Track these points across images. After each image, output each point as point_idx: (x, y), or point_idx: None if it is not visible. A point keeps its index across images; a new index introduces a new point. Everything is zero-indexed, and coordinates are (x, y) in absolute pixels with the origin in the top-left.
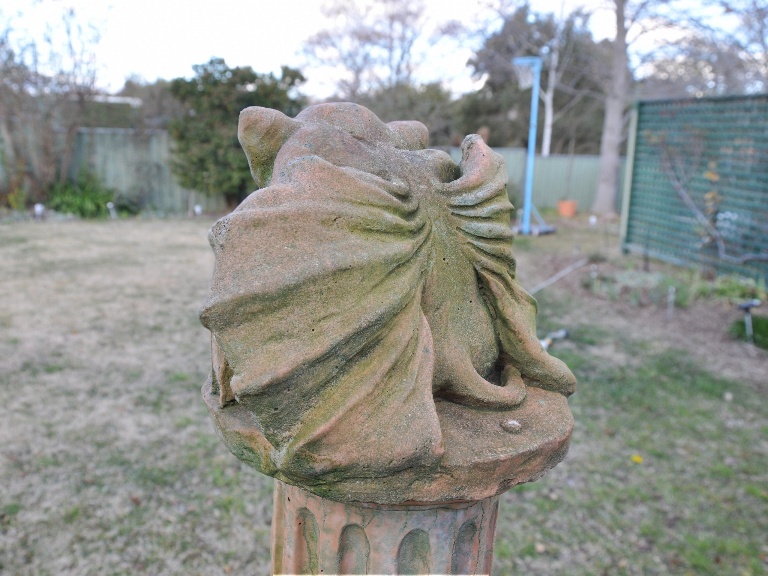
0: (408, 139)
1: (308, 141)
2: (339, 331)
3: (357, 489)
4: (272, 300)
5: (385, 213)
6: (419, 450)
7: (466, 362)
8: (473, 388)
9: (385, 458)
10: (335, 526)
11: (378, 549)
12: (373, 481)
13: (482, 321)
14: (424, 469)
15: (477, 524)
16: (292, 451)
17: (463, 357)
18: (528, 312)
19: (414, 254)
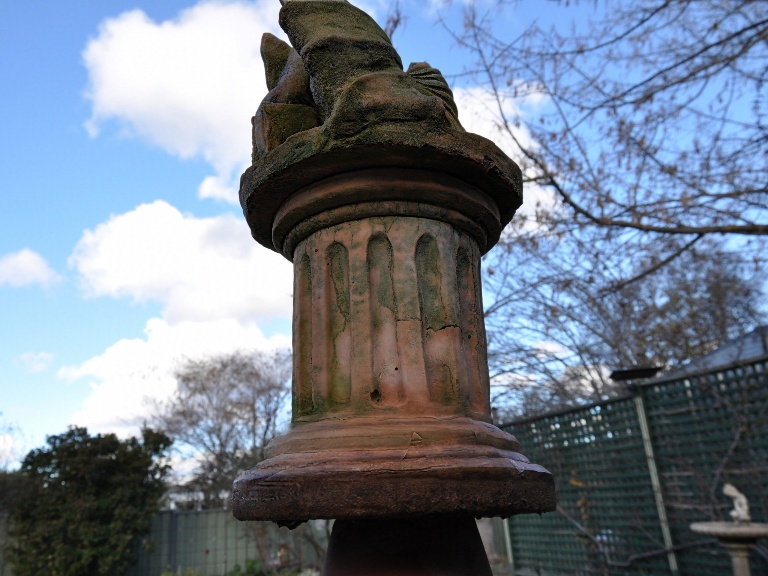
0: None
1: None
2: (368, 37)
3: (391, 129)
4: (328, 5)
5: None
6: (430, 102)
7: None
8: None
9: (408, 103)
10: (362, 239)
11: (399, 249)
12: (401, 125)
13: None
14: (434, 122)
15: (469, 258)
16: (346, 89)
17: None
18: None
19: None
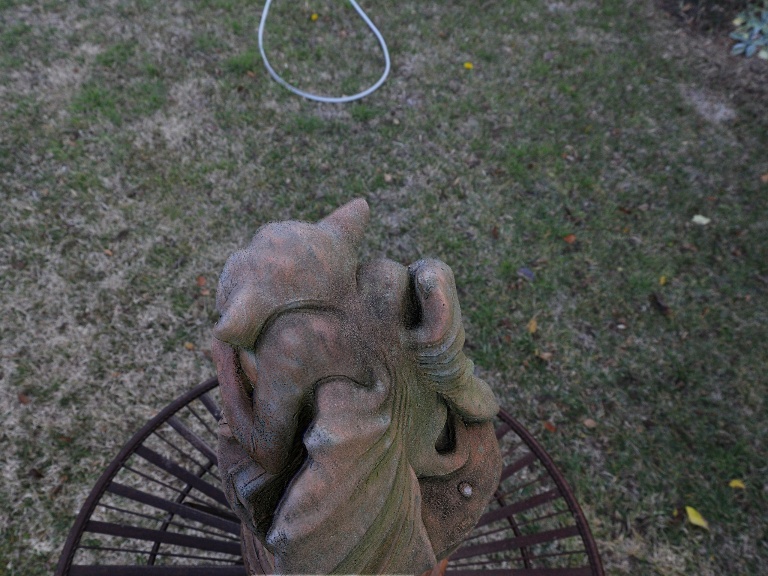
0: (355, 231)
1: (294, 353)
2: (371, 552)
3: None
4: None
5: (385, 440)
6: None
7: (433, 455)
8: (439, 471)
9: None
10: None
11: None
12: None
13: None
14: None
15: None
16: None
17: (431, 453)
18: None
19: None
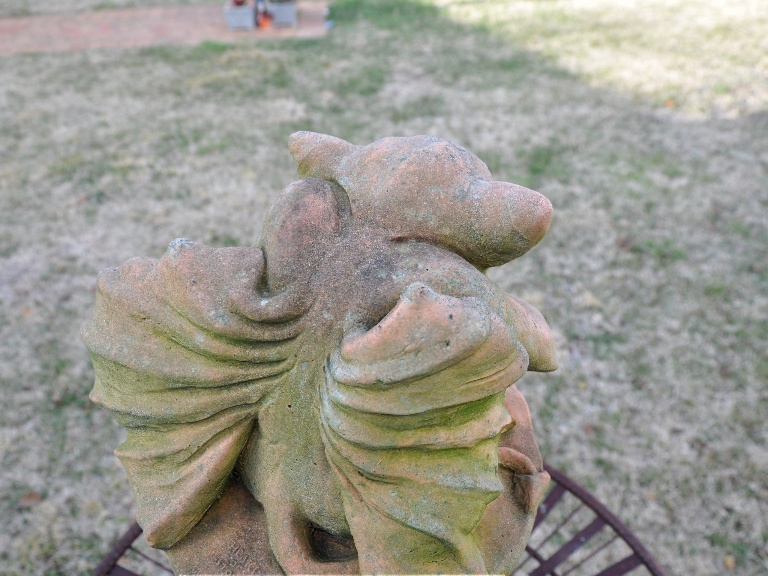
0: (486, 219)
1: None
2: (120, 403)
3: None
4: None
5: (199, 334)
6: None
7: (282, 507)
8: (272, 532)
9: None
10: None
11: None
12: None
13: (327, 490)
14: None
15: None
16: None
17: (282, 501)
18: (387, 529)
19: (244, 382)
